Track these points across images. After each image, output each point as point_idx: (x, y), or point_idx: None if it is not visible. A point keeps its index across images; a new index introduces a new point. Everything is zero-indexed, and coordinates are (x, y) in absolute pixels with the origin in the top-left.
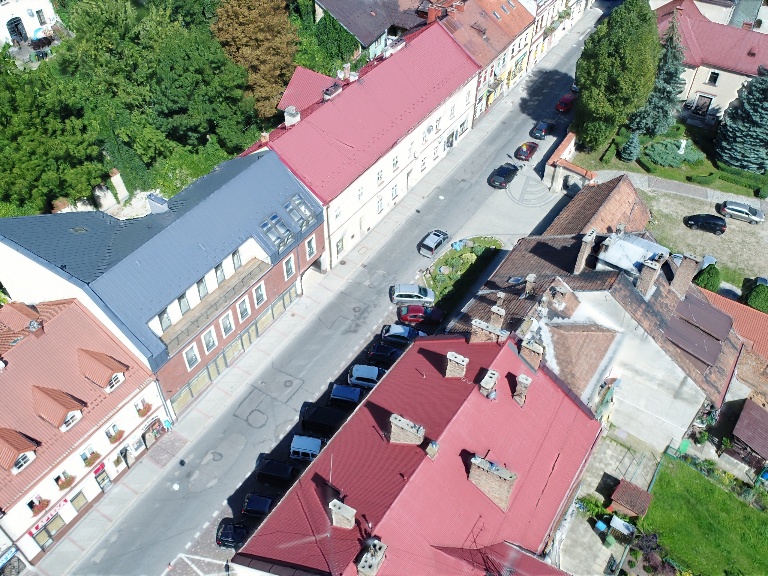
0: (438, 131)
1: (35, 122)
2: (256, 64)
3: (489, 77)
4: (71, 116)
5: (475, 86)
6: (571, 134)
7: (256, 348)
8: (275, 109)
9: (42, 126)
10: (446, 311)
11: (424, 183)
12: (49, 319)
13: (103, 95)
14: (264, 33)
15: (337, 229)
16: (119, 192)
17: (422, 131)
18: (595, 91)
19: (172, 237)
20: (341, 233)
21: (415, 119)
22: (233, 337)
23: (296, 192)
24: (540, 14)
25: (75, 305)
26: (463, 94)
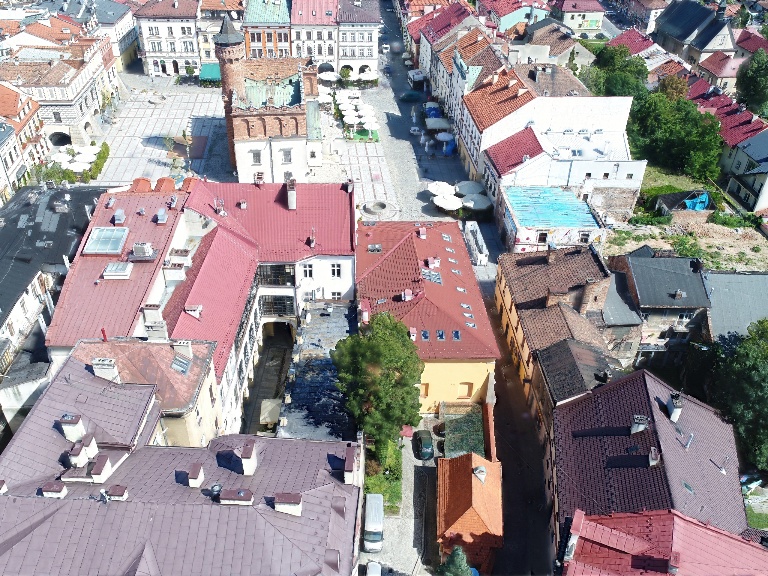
0: None
1: None
2: None
3: None
4: None
5: None
6: None
7: None
8: None
9: None
10: None
11: None
12: None
13: None
14: None
15: None
16: None
17: None
18: None
19: None
20: None
21: None
22: None
23: None
24: None
25: None
26: None
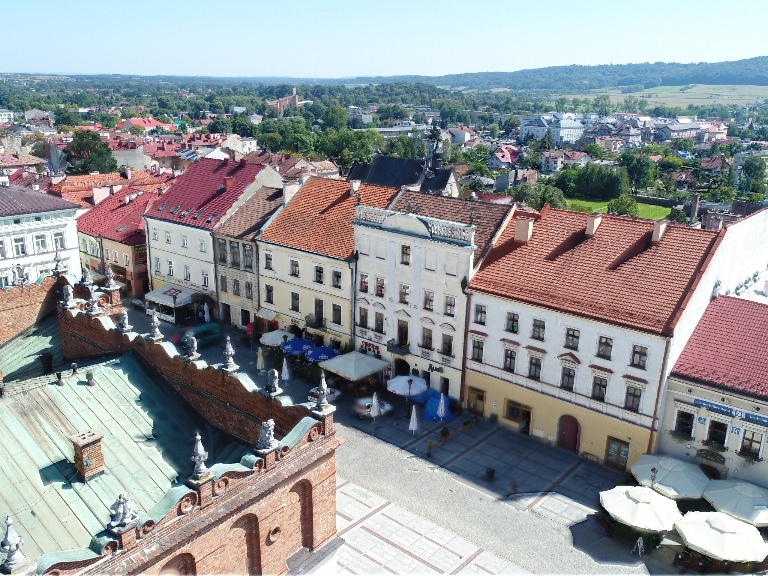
0: None
1: None
2: None
3: None
4: None
5: None
6: None
7: None
8: None
9: None
10: None
11: None
12: None
13: None
14: None
15: None
16: None
17: None
18: None
19: None
20: None
21: None
22: None
23: None
24: None
25: None
26: None
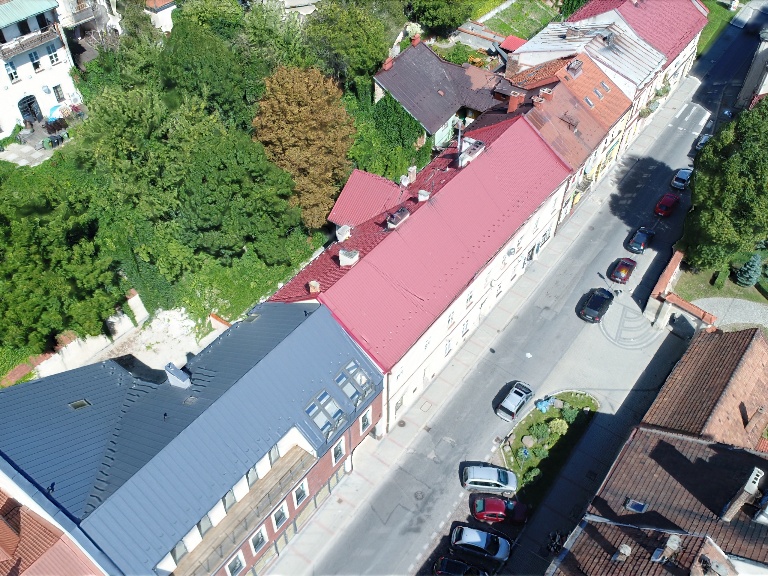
0: (519, 250)
1: (33, 259)
2: (304, 167)
3: (578, 177)
4: (81, 238)
5: (563, 191)
6: (678, 253)
7: (293, 550)
8: (325, 219)
9: (44, 256)
10: (531, 504)
11: (499, 310)
12: (27, 564)
13: (122, 206)
14: (316, 131)
15: (397, 390)
16: (137, 314)
17: (502, 256)
18: (718, 215)
19: (193, 440)
20: (402, 392)
21: (495, 245)
22: (265, 549)
23: (351, 358)
24: (638, 97)
25: (62, 542)
26: (549, 203)
